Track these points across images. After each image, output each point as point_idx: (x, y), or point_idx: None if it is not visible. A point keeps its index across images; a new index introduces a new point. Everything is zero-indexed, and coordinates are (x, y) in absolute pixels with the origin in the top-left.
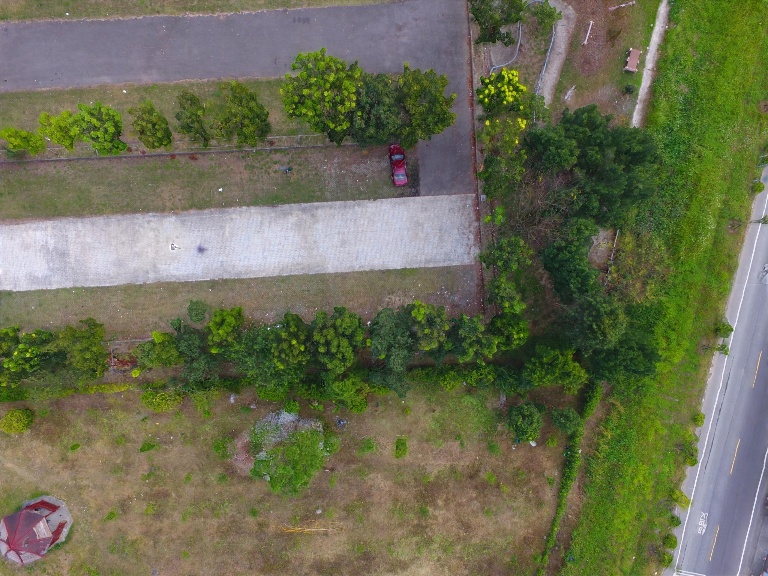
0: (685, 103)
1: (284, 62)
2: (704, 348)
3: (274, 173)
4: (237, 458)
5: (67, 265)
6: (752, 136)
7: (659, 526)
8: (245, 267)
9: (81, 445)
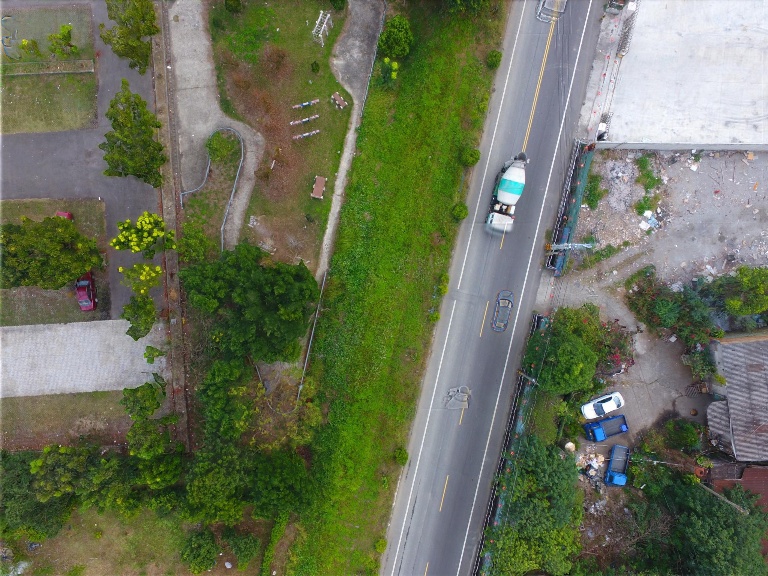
0: (367, 231)
1: None
2: None
3: None
4: None
5: None
6: (424, 267)
7: None
8: None
9: None
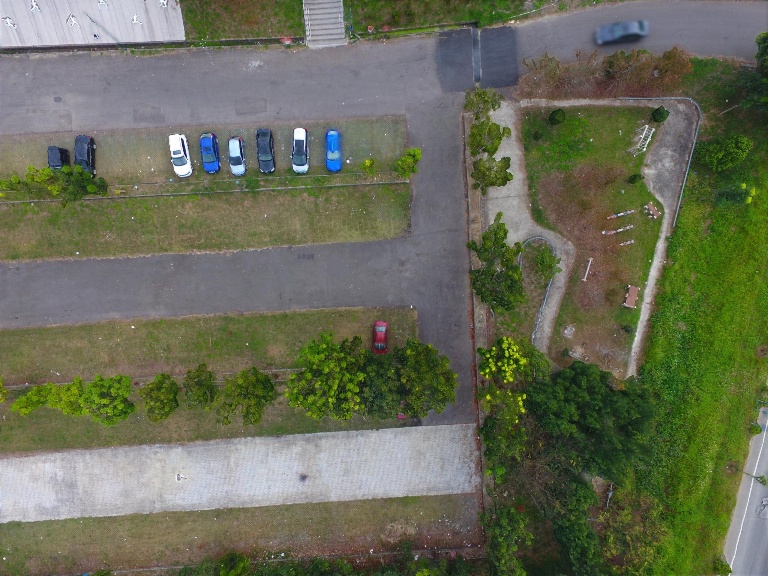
0: (683, 341)
1: (289, 297)
2: None
3: (279, 404)
4: None
5: (75, 496)
6: (749, 381)
7: None
8: (250, 496)
9: None
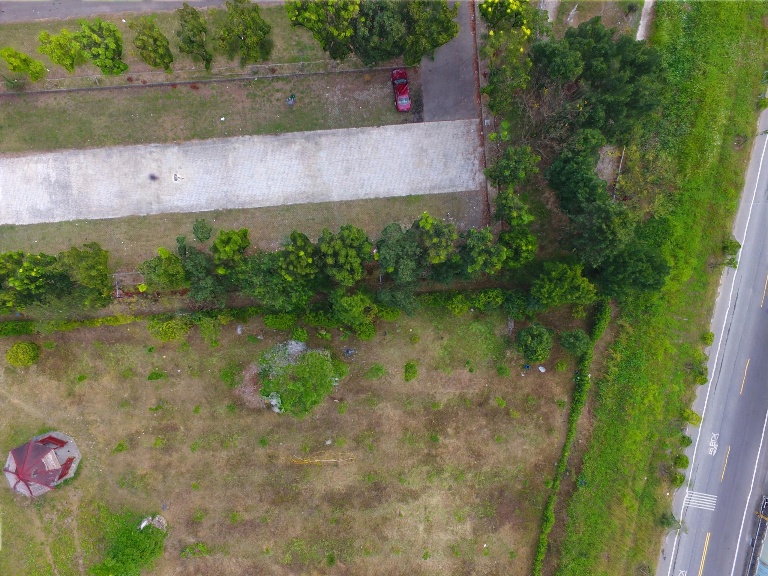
0: (688, 21)
1: None
2: (712, 266)
3: (276, 101)
4: (245, 390)
5: (70, 197)
6: (756, 51)
7: (670, 446)
8: (249, 197)
9: (88, 380)
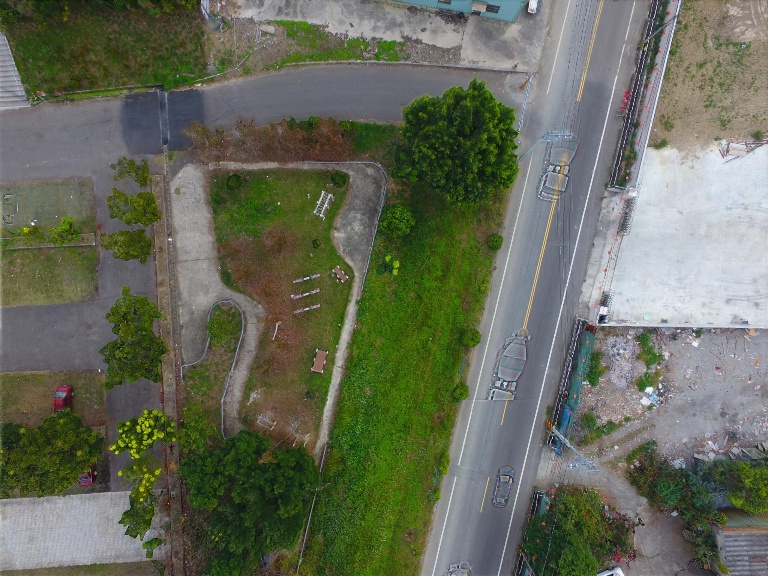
0: (367, 407)
1: None
2: None
3: None
4: None
5: None
6: (425, 448)
7: None
8: None
9: None
